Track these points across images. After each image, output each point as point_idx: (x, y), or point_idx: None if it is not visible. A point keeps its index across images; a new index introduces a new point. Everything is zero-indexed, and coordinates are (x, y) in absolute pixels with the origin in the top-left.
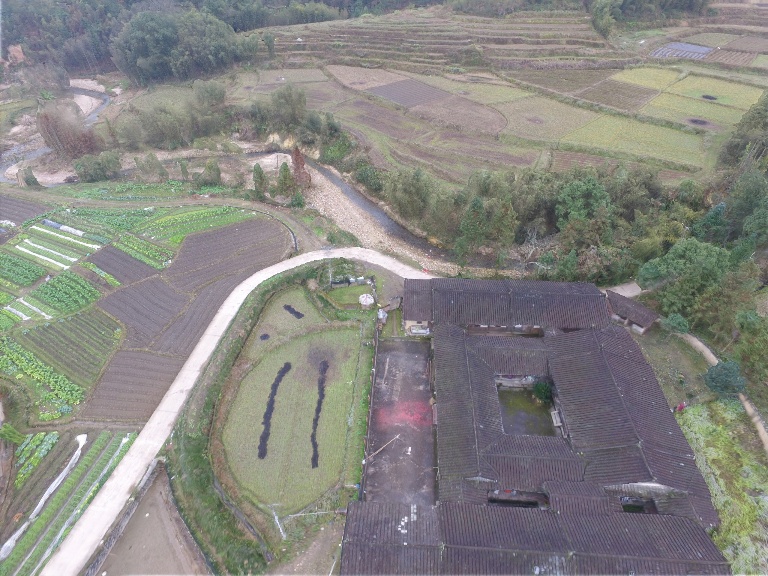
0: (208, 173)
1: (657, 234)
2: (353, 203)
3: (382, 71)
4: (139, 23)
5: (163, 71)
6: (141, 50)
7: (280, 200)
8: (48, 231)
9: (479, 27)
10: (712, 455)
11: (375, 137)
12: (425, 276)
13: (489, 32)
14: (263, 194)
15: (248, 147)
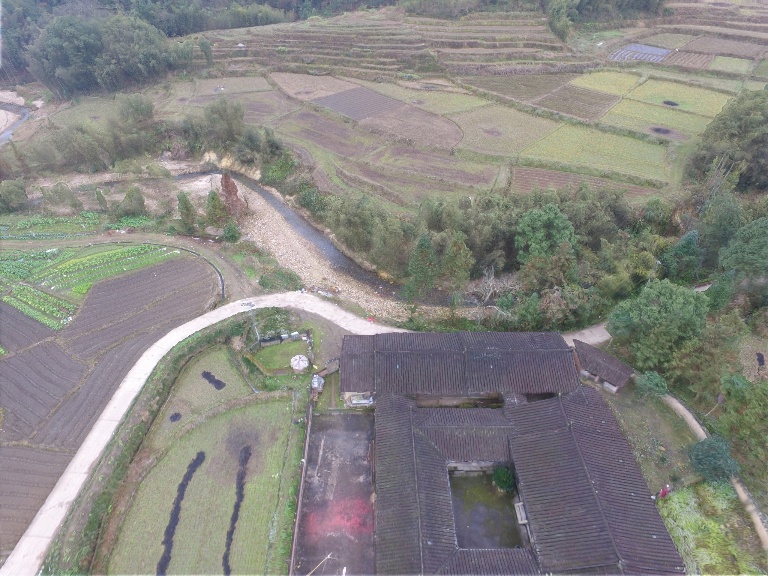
0: (128, 202)
1: (626, 268)
2: (296, 232)
3: (331, 78)
4: (56, 29)
5: (88, 81)
6: (61, 59)
7: (212, 231)
8: None
9: (433, 30)
10: (704, 560)
11: (320, 155)
12: (370, 326)
13: (443, 35)
14: (192, 225)
15: (181, 168)
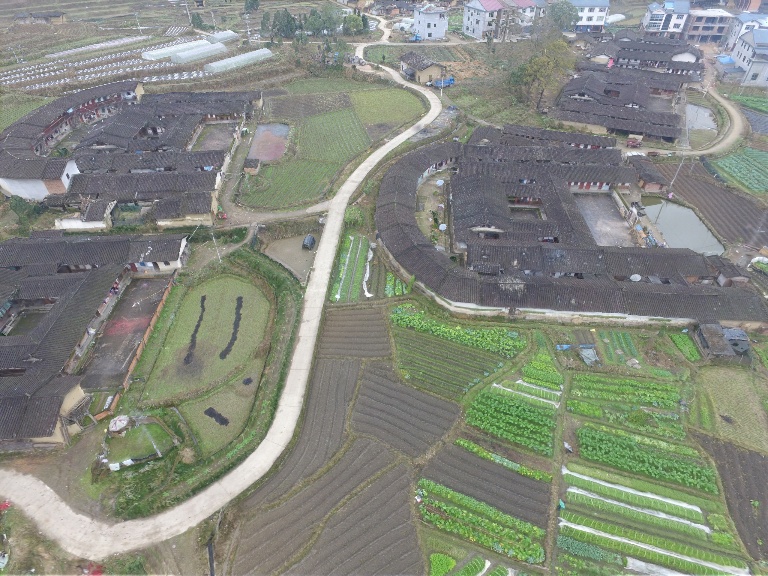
0: None
1: None
2: None
3: None
4: None
5: None
6: None
7: None
8: (703, 563)
9: None
10: None
11: None
12: (13, 493)
13: None
14: None
15: None
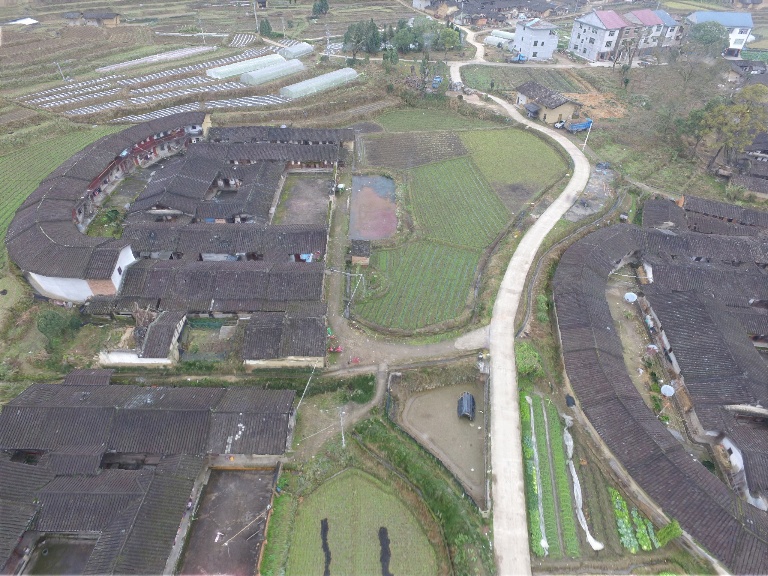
0: None
1: None
2: None
3: None
4: None
5: None
6: None
7: None
8: None
9: None
10: None
11: None
12: None
13: None
14: None
15: None
